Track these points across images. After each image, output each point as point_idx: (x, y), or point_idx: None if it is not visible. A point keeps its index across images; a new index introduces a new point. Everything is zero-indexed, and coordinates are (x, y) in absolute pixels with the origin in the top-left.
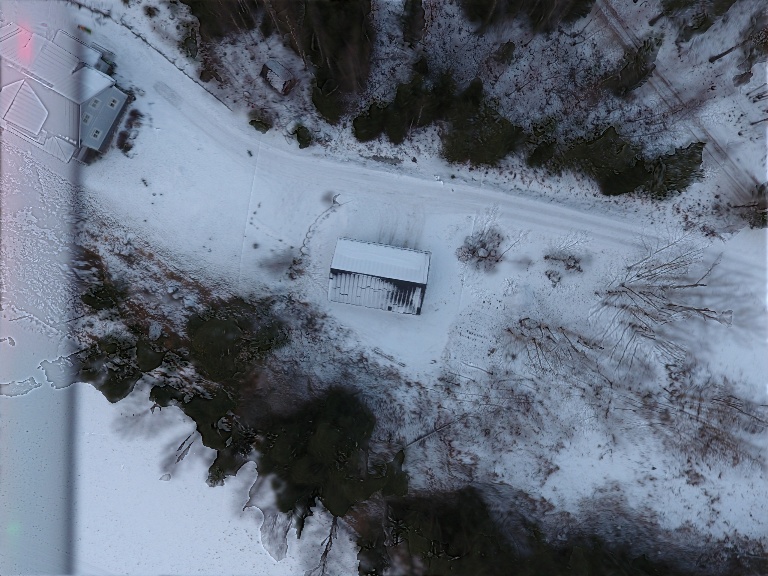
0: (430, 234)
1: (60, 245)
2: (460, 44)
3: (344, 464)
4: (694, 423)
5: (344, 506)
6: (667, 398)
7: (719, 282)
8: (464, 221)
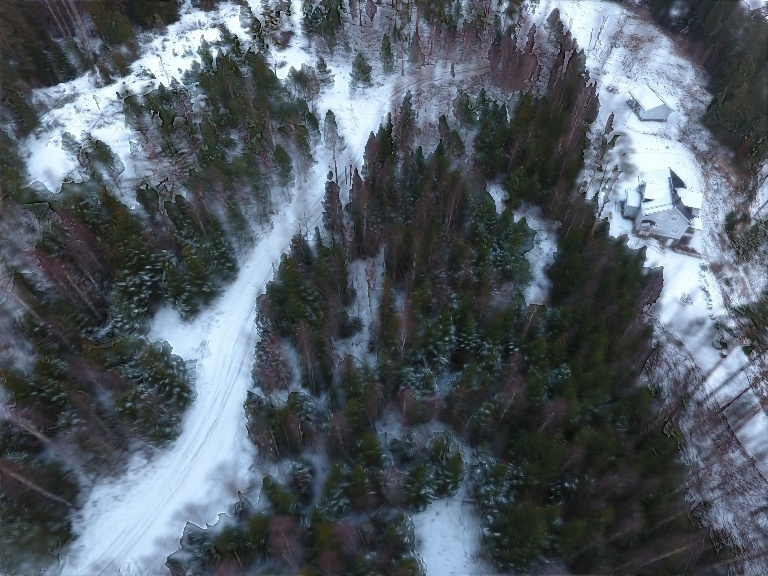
0: (615, 100)
1: (735, 249)
2: (535, 92)
3: (744, 71)
4: (632, 41)
5: (758, 74)
6: (627, 47)
7: (577, 41)
8: (602, 93)
